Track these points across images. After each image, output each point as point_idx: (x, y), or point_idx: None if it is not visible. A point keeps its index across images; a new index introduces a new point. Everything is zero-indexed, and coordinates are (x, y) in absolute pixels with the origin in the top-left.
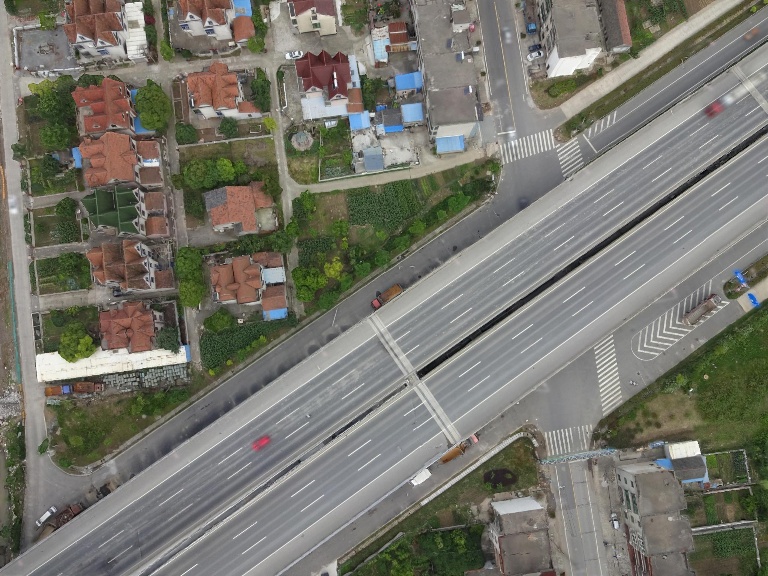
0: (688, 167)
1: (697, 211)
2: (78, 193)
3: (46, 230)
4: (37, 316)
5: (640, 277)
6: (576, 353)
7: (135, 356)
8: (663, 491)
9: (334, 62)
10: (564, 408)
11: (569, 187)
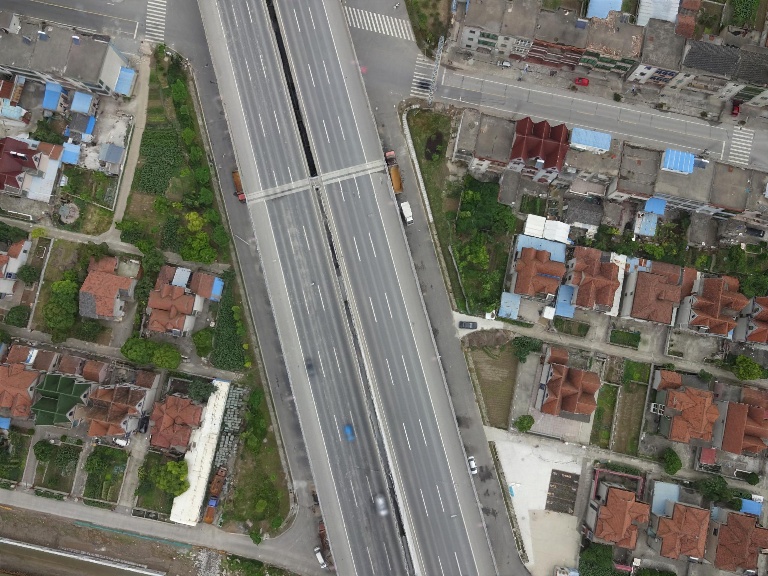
0: None
1: None
2: (35, 437)
3: (58, 478)
4: (136, 512)
5: None
6: (347, 37)
7: (205, 428)
8: (485, 8)
9: (1, 151)
10: (395, 71)
11: None
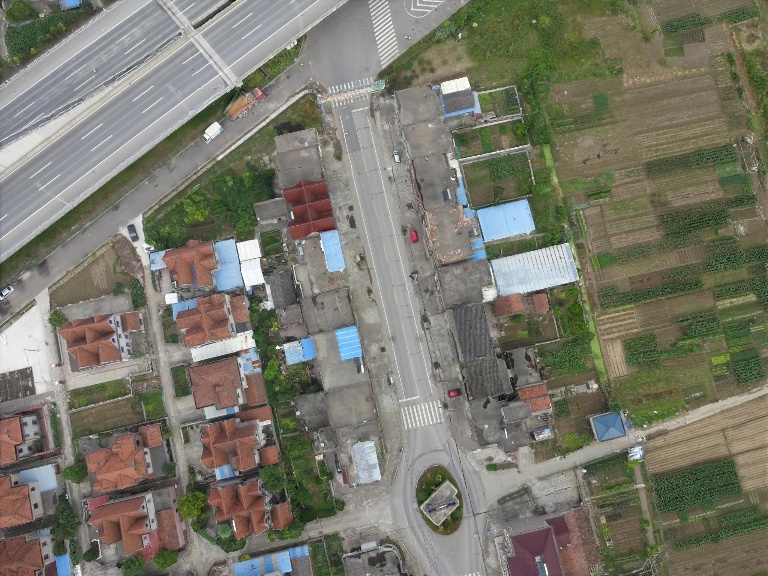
0: None
1: None
2: None
3: None
4: None
5: None
6: None
7: None
8: (422, 103)
9: None
10: (345, 65)
11: None
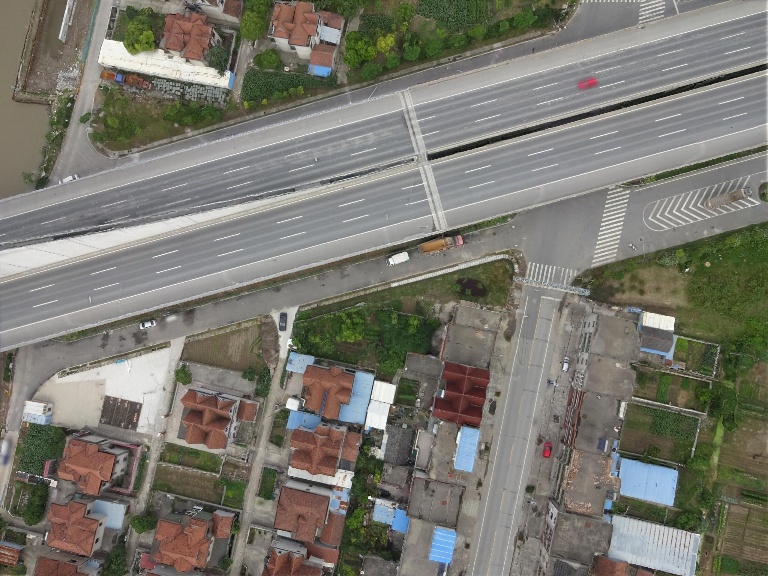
0: (767, 52)
1: (760, 97)
2: None
3: None
4: (116, 10)
5: (676, 140)
6: (585, 189)
7: (185, 67)
8: (621, 338)
9: None
10: (556, 246)
11: (638, 34)
